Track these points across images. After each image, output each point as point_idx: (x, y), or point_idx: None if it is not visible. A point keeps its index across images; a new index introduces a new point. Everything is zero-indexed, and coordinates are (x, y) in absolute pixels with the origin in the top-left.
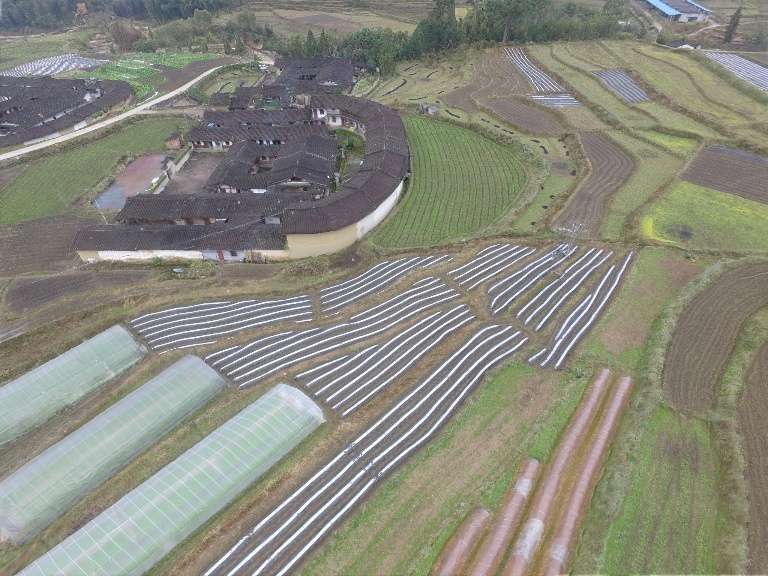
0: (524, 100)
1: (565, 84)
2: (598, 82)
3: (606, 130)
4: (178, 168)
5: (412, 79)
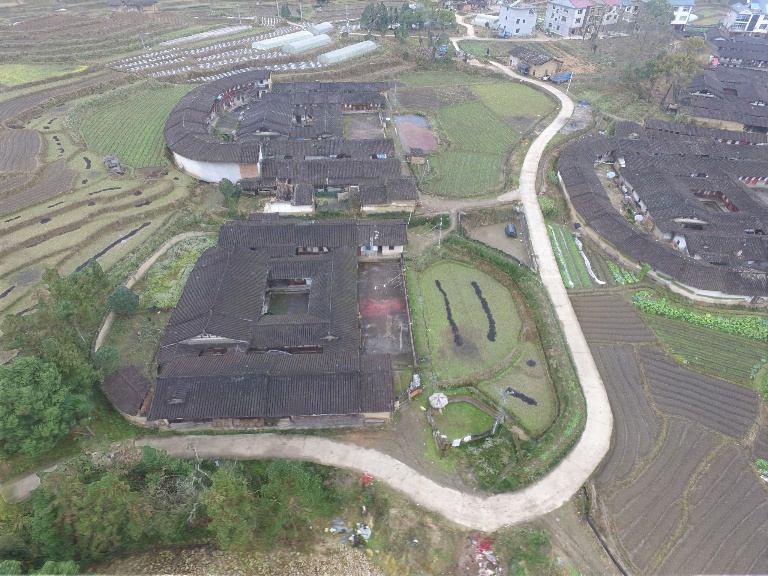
0: None
1: None
2: None
3: None
4: None
5: None
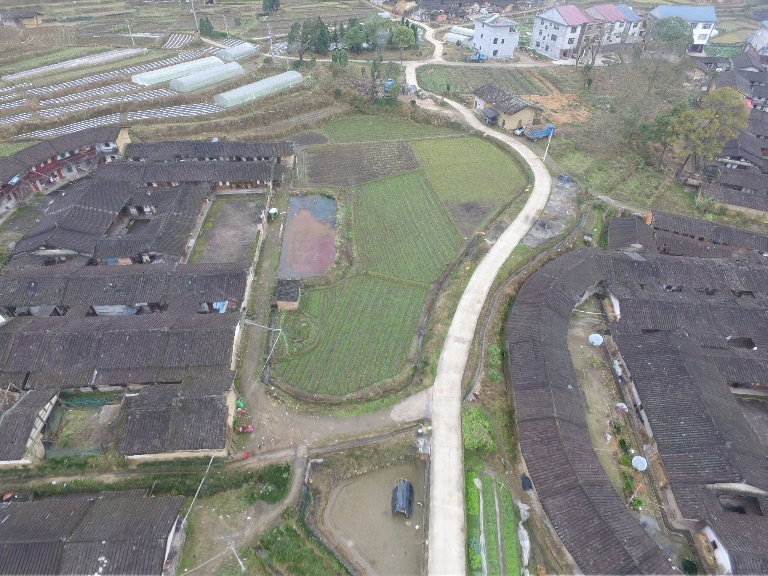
0: None
1: None
2: None
3: None
4: None
5: None
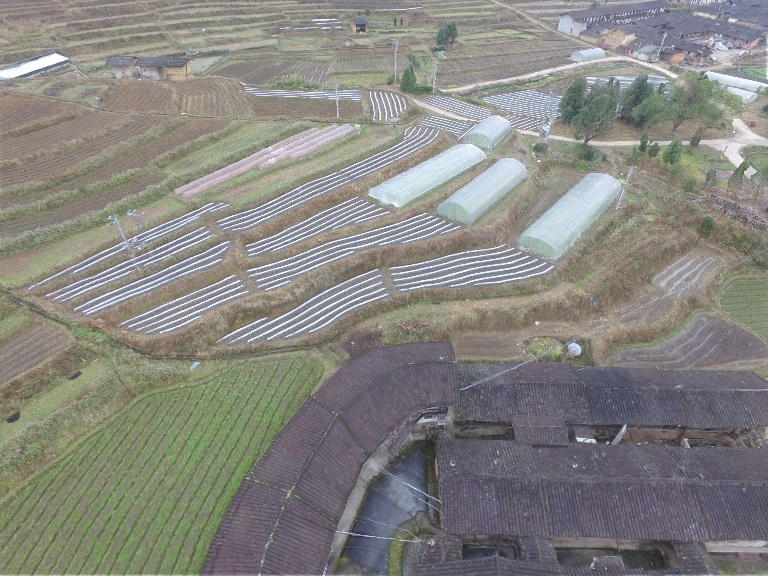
0: None
1: None
2: None
3: None
4: None
5: None
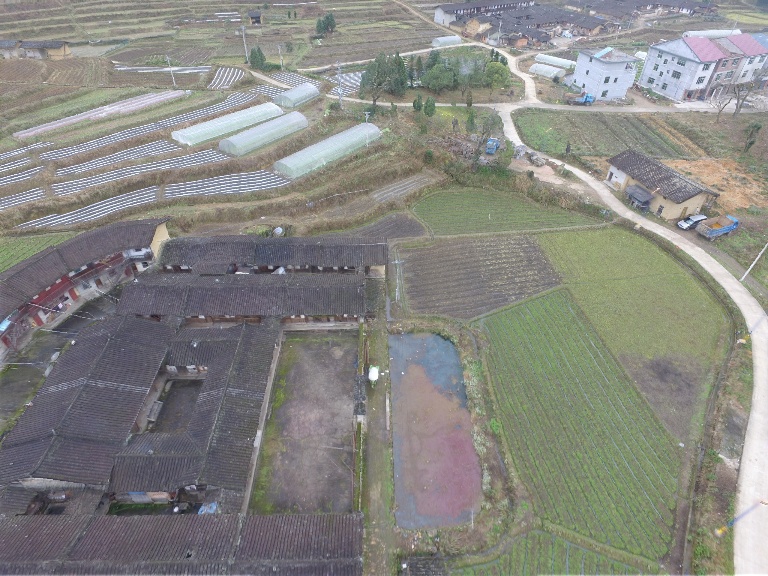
0: None
1: None
2: None
3: None
4: None
5: None
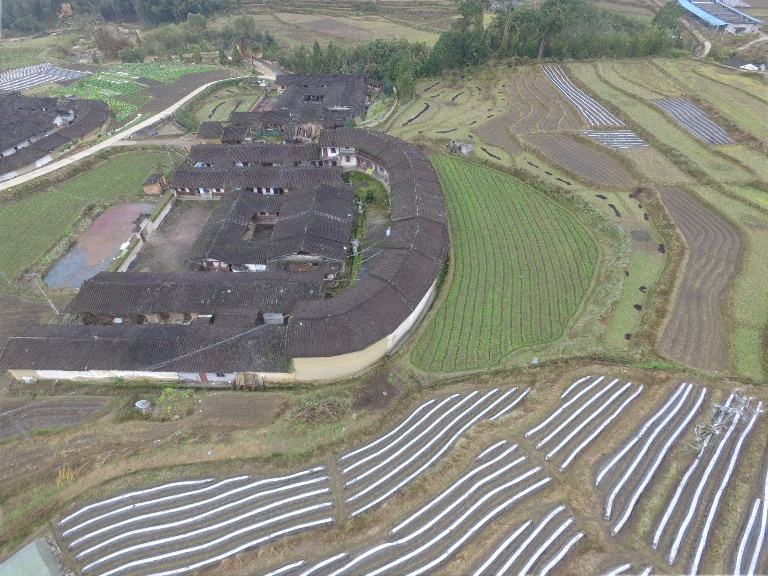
0: (577, 137)
1: (623, 116)
2: (663, 114)
3: (691, 185)
4: (156, 225)
5: (435, 103)
